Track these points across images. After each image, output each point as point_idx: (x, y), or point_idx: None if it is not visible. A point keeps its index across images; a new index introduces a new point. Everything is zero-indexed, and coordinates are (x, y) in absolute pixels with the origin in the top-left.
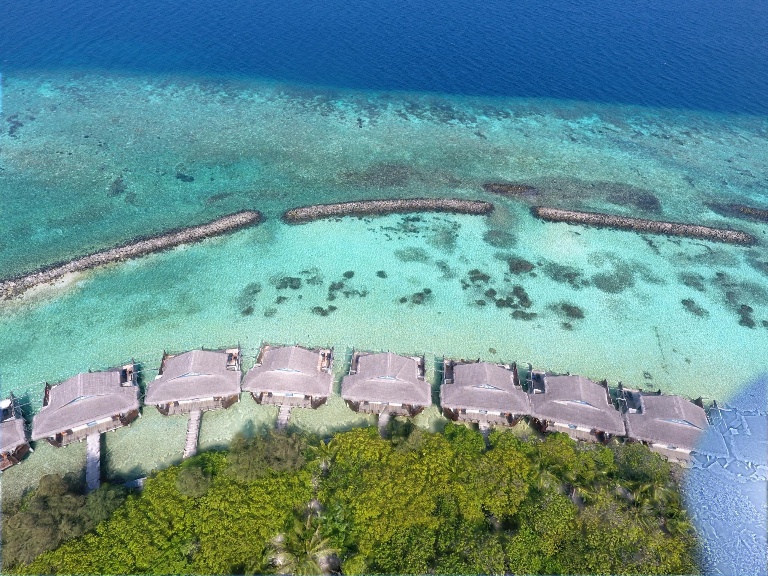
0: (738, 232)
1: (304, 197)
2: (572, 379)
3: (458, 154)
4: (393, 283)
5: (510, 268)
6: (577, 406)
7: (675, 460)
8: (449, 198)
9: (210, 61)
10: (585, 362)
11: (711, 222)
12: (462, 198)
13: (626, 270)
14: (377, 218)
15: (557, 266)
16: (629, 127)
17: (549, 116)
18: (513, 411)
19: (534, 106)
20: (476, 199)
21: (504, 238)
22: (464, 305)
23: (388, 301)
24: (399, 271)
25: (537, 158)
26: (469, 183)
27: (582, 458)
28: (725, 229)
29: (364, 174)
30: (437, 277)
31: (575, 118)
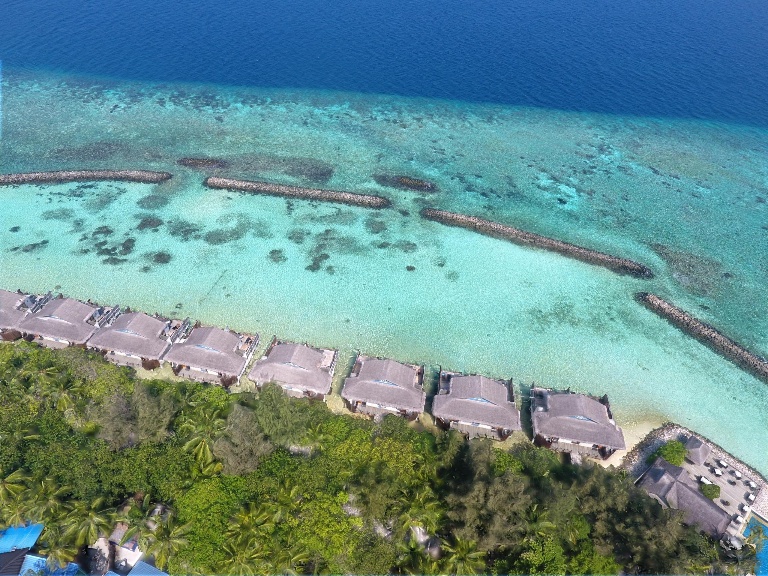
0: (377, 197)
1: (2, 168)
2: (62, 300)
3: (182, 135)
4: (19, 236)
5: (138, 225)
6: (55, 321)
7: (124, 364)
8: (137, 170)
9: (5, 55)
10: (134, 296)
11: (364, 190)
12: (149, 170)
13: (245, 227)
14: (54, 185)
15: (184, 224)
16: (369, 113)
17: (302, 104)
18: (1, 326)
19: (296, 95)
20: (162, 171)
21: (157, 202)
22: (67, 253)
23: (0, 250)
24: (33, 227)
25: (254, 138)
26: (168, 158)
27: (4, 355)
28: (370, 195)
29: (75, 150)
30: (64, 232)
31: (325, 106)
